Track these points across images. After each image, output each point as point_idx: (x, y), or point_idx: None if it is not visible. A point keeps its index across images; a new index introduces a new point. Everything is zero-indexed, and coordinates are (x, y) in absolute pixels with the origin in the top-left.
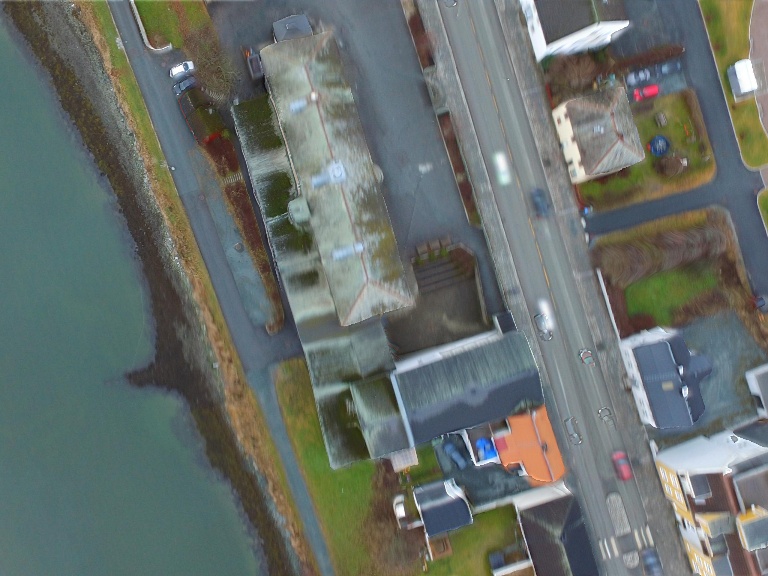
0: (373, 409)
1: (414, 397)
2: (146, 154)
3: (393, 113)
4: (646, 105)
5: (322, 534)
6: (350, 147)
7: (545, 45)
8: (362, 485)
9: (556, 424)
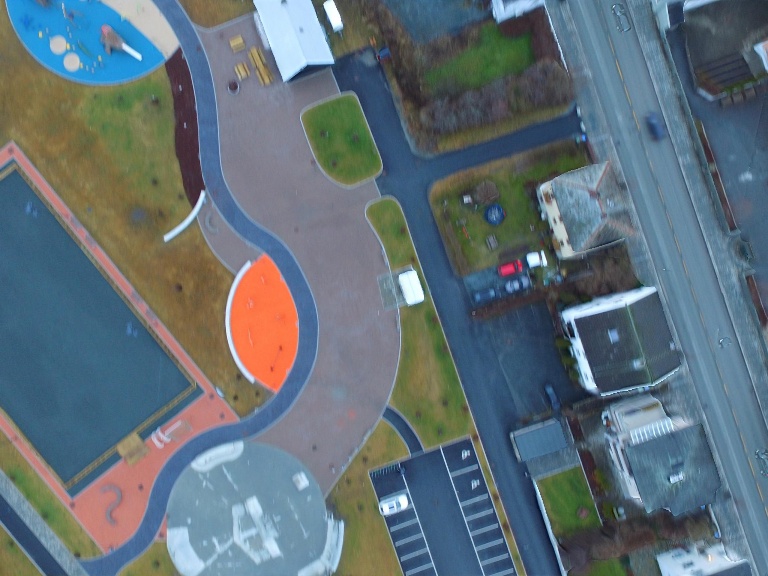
0: None
1: None
2: None
3: None
4: (507, 257)
5: None
6: None
7: None
8: None
9: None
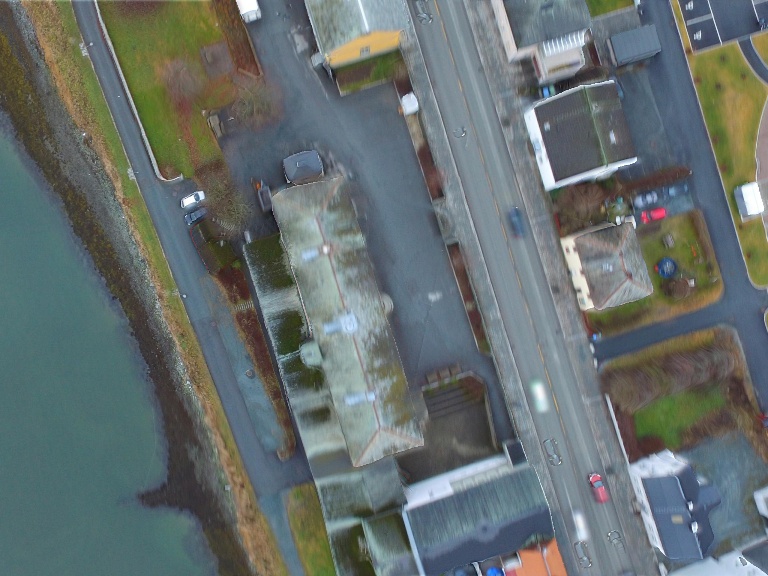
0: (385, 547)
1: (426, 534)
2: (158, 282)
3: (403, 243)
4: (653, 226)
5: None
6: (361, 294)
7: (554, 181)
8: None
9: (566, 548)
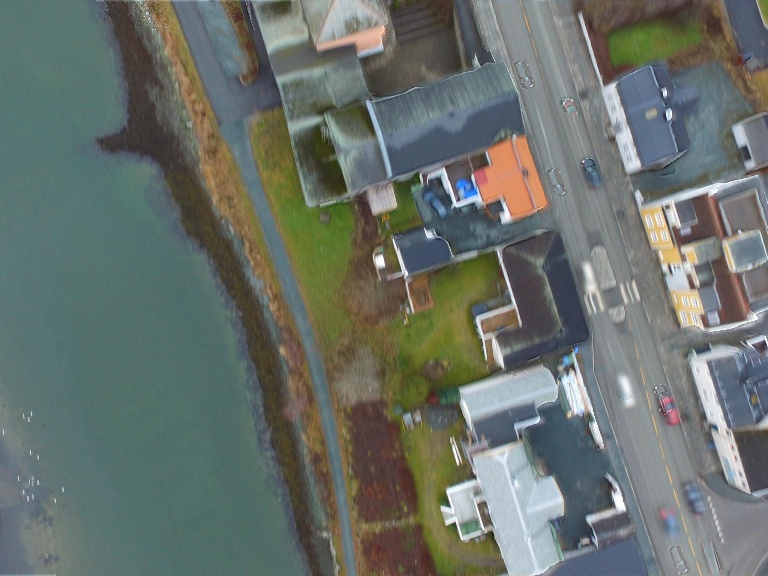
0: (348, 134)
1: (391, 122)
2: None
3: None
4: None
5: (301, 295)
6: None
7: None
8: (341, 243)
9: (539, 174)
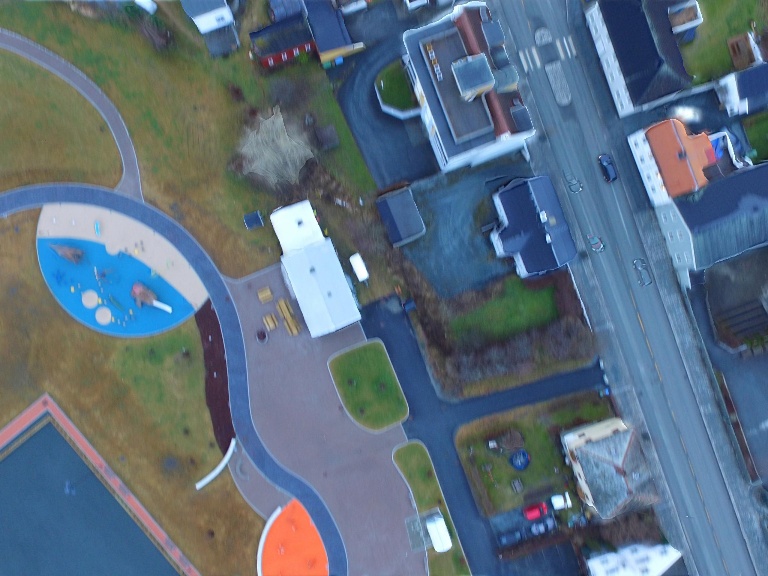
0: None
1: None
2: None
3: None
4: (532, 499)
5: None
6: None
7: None
8: None
9: (627, 175)
